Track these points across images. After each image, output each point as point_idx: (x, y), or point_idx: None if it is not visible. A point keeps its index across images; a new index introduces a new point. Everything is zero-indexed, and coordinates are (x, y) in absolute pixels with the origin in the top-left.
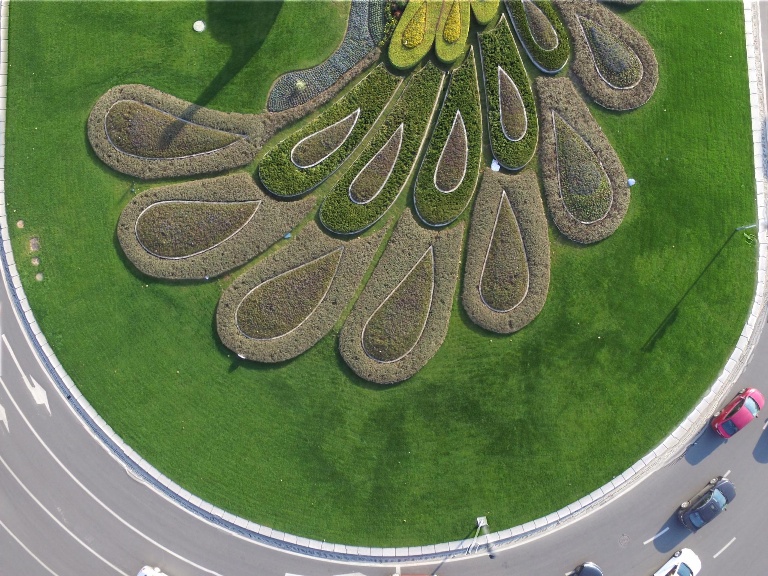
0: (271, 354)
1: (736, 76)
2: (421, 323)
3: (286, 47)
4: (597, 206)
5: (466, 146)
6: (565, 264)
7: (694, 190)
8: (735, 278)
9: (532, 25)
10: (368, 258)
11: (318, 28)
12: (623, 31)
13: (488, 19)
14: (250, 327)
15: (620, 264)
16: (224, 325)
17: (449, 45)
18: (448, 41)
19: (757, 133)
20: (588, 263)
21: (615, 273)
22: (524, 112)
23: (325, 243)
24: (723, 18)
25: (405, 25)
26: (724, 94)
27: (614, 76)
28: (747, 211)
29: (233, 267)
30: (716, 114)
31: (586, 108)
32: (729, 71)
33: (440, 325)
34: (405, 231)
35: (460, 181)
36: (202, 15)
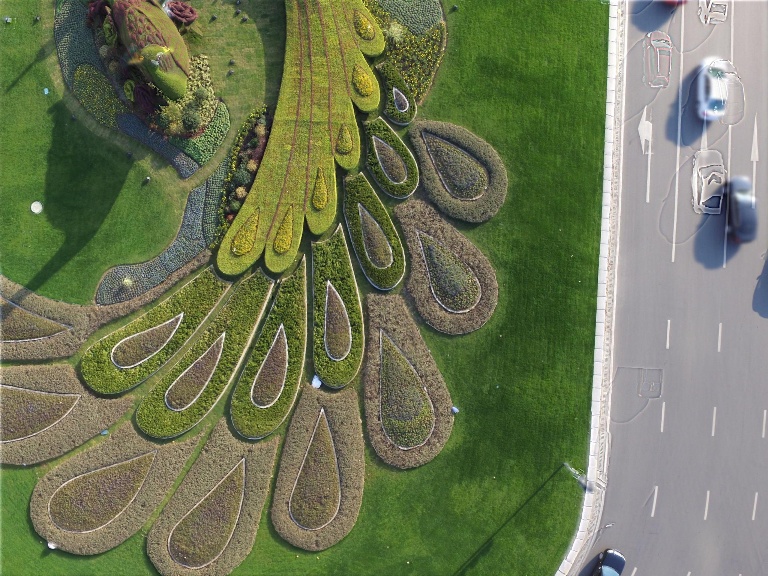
0: (79, 548)
1: (583, 302)
2: (228, 534)
3: (118, 239)
4: (416, 433)
5: (286, 362)
6: (379, 487)
7: (523, 421)
8: (558, 512)
9: (367, 240)
10: (180, 464)
11: (152, 222)
12: (463, 252)
13: (322, 231)
14: (61, 519)
15: (437, 491)
16: (37, 514)
17: (278, 256)
18: (277, 252)
19: (598, 364)
20: (403, 488)
21: (431, 500)
22: (349, 331)
23: (138, 445)
24: (576, 240)
25: (236, 230)
26: (567, 321)
27: (449, 299)
28: (578, 445)
29: (49, 458)
30: (556, 342)
31: (417, 329)
32: (576, 297)
33: (246, 538)
34: (218, 442)
35: (277, 397)
36: (40, 196)
